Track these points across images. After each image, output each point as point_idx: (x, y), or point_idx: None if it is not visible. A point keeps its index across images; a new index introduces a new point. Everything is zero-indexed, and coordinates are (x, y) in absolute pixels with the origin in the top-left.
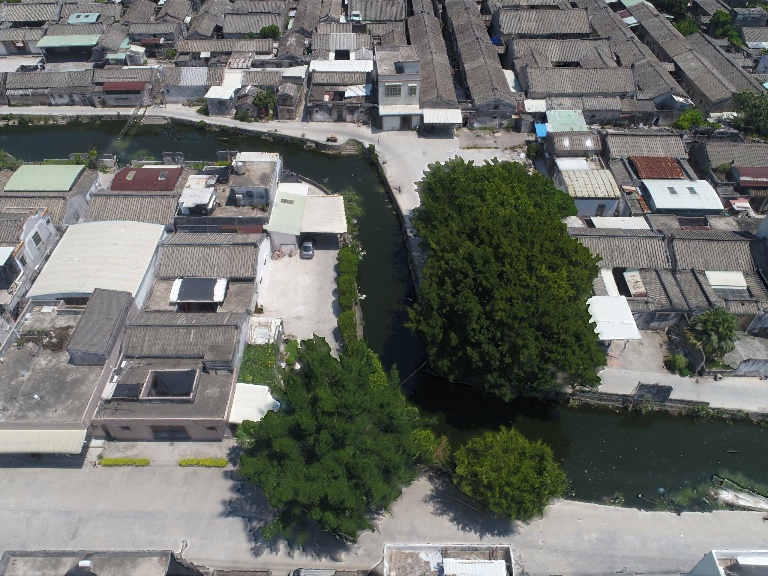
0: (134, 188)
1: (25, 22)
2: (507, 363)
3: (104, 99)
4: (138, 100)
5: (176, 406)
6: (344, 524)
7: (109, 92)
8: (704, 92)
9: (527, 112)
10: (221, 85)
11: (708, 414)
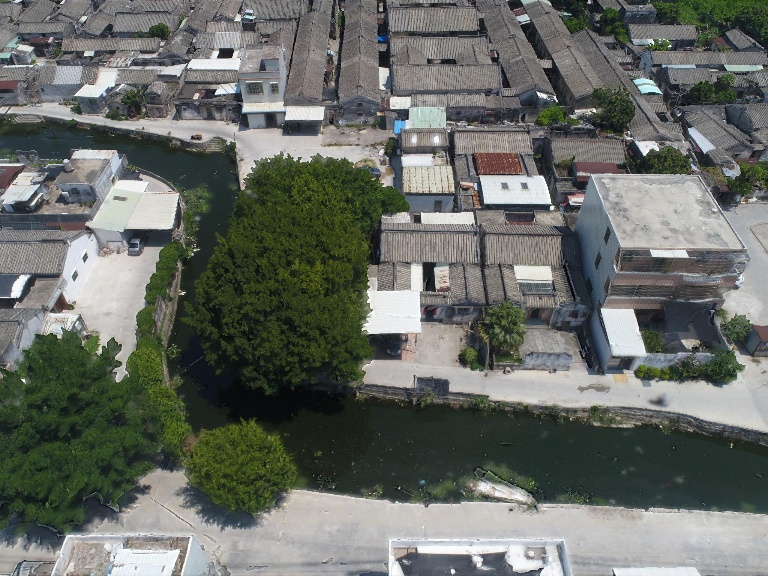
0: None
1: None
2: (258, 356)
3: None
4: (13, 99)
5: None
6: (46, 516)
7: None
8: (570, 89)
9: (391, 109)
10: (95, 84)
11: (489, 407)
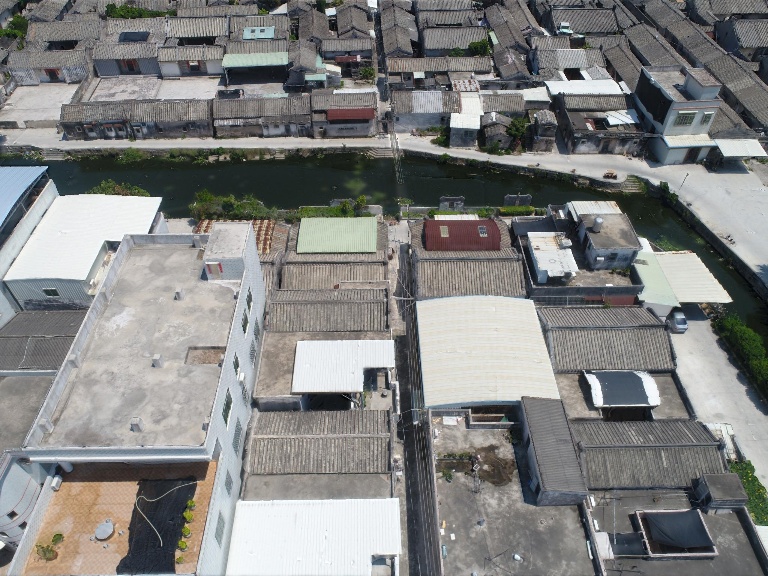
0: (454, 248)
1: (191, 38)
2: None
3: (326, 129)
4: (364, 130)
5: (693, 564)
6: None
7: (333, 121)
8: None
9: None
10: (460, 112)
11: None
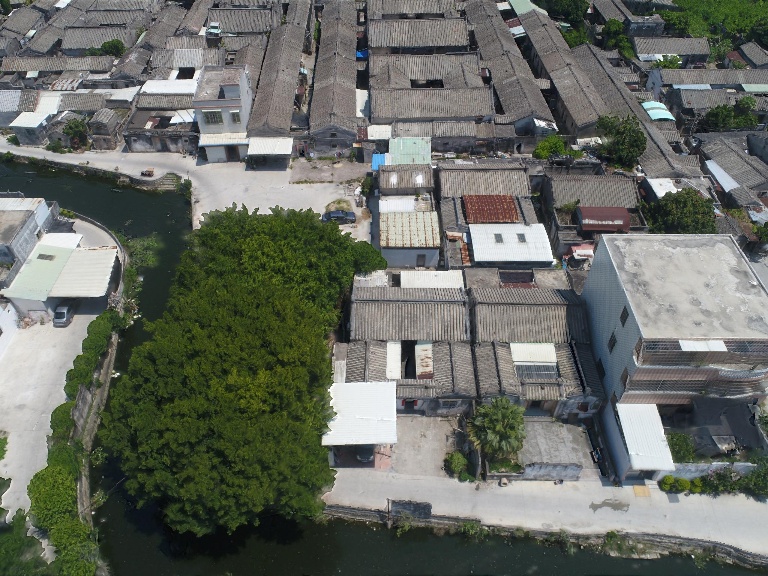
0: None
1: None
2: None
3: None
4: None
5: None
6: None
7: None
8: (572, 114)
9: (370, 140)
10: (34, 111)
11: (481, 533)
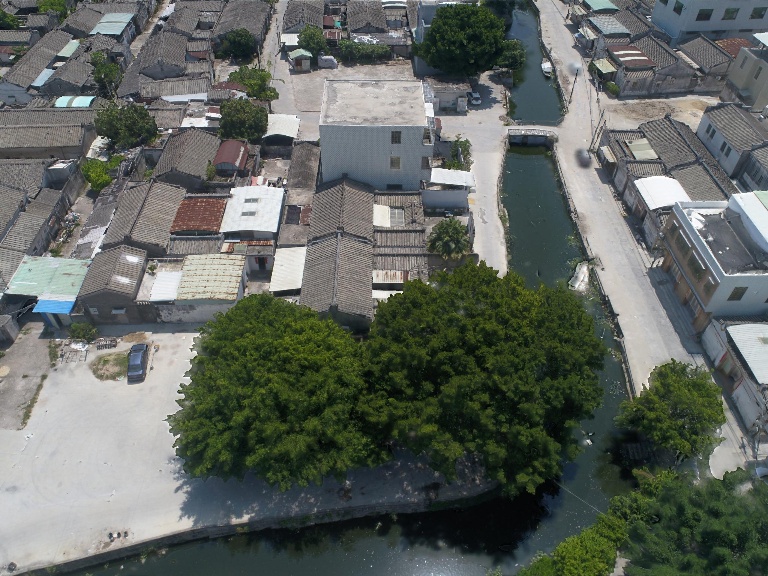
0: None
1: None
2: None
3: None
4: None
5: None
6: None
7: None
8: (53, 145)
9: None
10: None
11: None
